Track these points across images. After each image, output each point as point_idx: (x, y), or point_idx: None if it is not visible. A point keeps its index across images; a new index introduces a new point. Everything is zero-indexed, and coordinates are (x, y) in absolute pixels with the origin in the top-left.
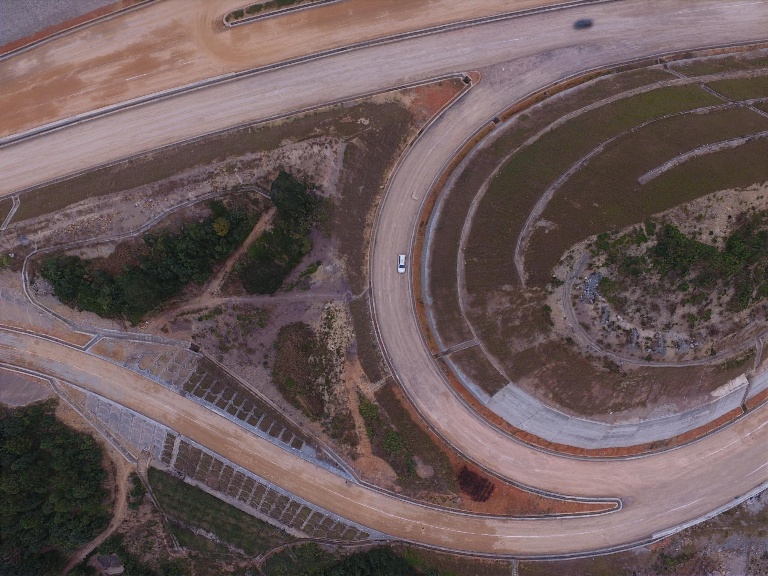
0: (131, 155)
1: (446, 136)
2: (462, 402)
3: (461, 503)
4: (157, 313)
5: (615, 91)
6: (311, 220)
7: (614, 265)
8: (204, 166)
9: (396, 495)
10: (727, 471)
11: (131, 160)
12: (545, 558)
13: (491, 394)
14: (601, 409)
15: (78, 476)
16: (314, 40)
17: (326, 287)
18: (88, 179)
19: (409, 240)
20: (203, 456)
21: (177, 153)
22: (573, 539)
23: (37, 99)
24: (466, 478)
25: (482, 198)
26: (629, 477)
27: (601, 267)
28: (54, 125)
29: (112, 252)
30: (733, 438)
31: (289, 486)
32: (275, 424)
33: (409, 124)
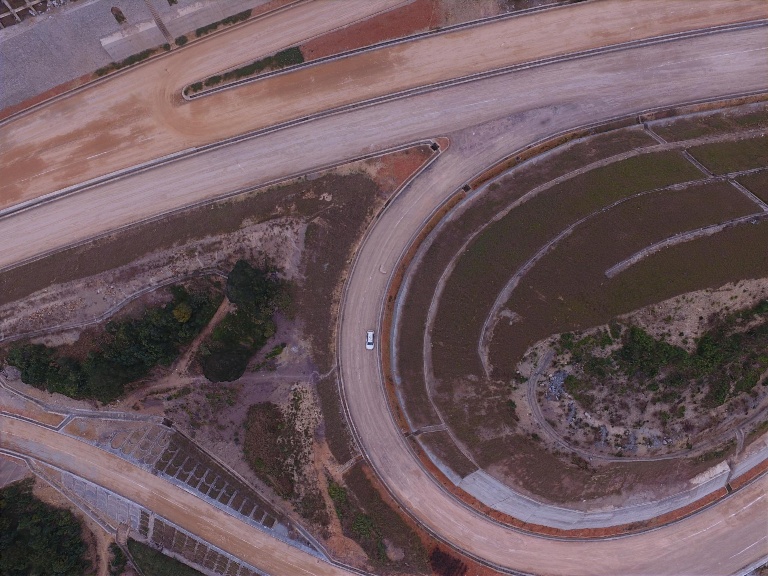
0: (95, 235)
1: (414, 206)
2: (434, 481)
3: None
4: (127, 391)
5: (589, 160)
6: (273, 305)
7: (579, 364)
8: (164, 251)
9: (368, 574)
10: (710, 553)
11: (95, 240)
12: None
13: (462, 476)
14: (573, 498)
15: (57, 552)
16: (276, 110)
17: (292, 368)
18: (53, 261)
19: (377, 315)
20: (177, 533)
21: (140, 232)
22: None
23: (0, 181)
24: (438, 559)
25: (449, 277)
26: (607, 558)
27: (566, 365)
28: (18, 207)
29: (76, 339)
30: (717, 519)
31: (261, 564)
32: (247, 502)
33: (375, 195)
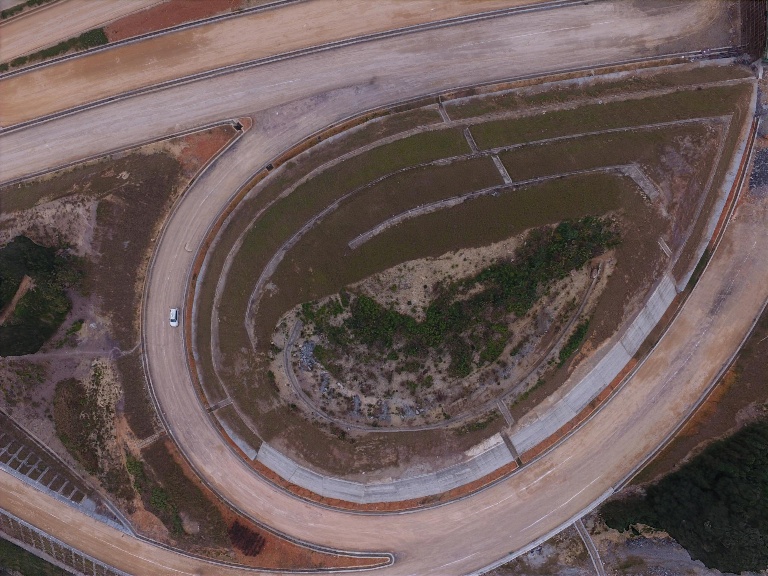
0: None
1: (219, 185)
2: (235, 456)
3: (234, 557)
4: None
5: (375, 137)
6: (62, 281)
7: (323, 334)
8: None
9: (172, 548)
10: (501, 526)
11: None
12: None
13: (256, 450)
14: (350, 470)
15: None
16: (82, 91)
17: (92, 344)
18: None
19: (183, 293)
20: None
21: None
22: None
23: None
24: (236, 533)
25: (236, 254)
26: (402, 531)
27: (312, 335)
28: None
29: None
30: (508, 492)
31: (69, 539)
32: (58, 477)
33: (179, 174)
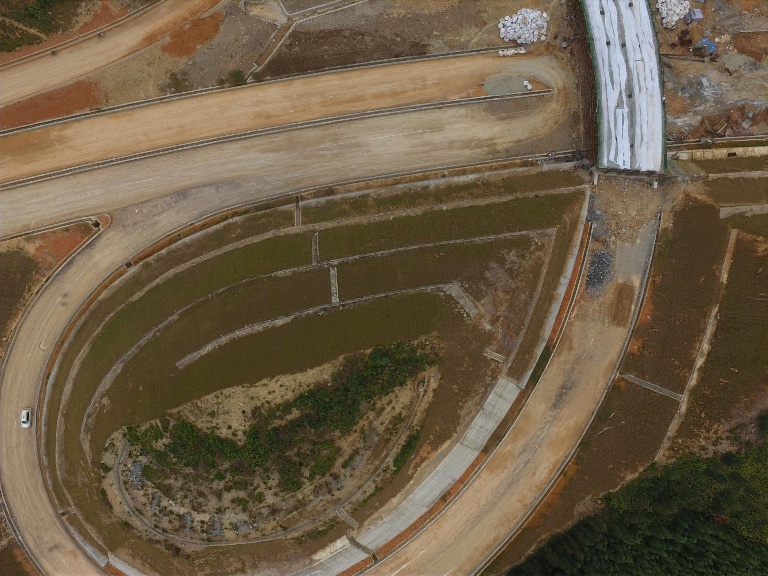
0: None
1: (76, 282)
2: (89, 561)
3: None
4: None
5: (227, 241)
6: None
7: (150, 455)
8: None
9: None
10: None
11: None
12: None
13: (107, 556)
14: None
15: None
16: None
17: None
18: None
19: (37, 392)
20: None
21: None
22: None
23: None
24: None
25: (84, 358)
26: None
27: (140, 456)
28: None
29: None
30: None
31: None
32: None
33: (34, 272)
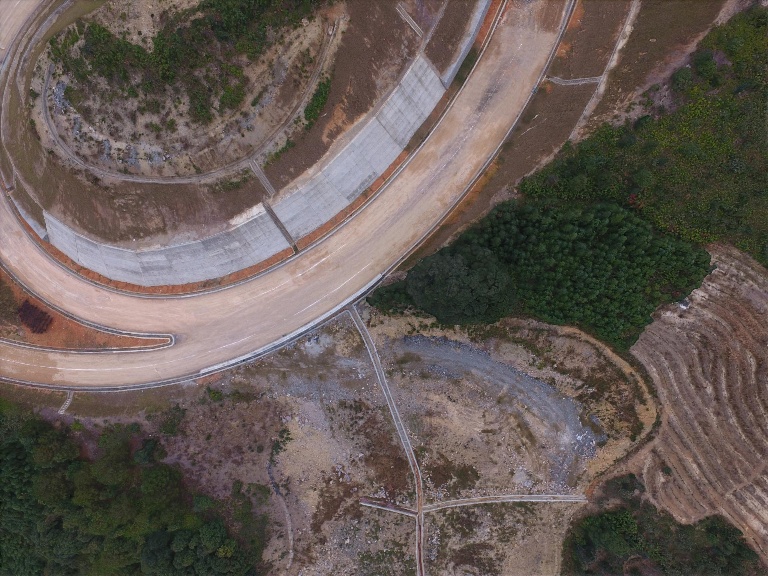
0: None
1: None
2: (32, 241)
3: (23, 336)
4: None
5: None
6: None
7: (71, 72)
8: None
9: None
10: (277, 310)
11: None
12: (99, 390)
13: (46, 229)
14: (119, 234)
15: None
16: None
17: None
18: None
19: None
20: None
21: None
22: (128, 373)
23: None
24: (25, 310)
25: None
26: (184, 315)
27: (62, 75)
28: None
29: None
30: (285, 278)
31: None
32: None
33: None
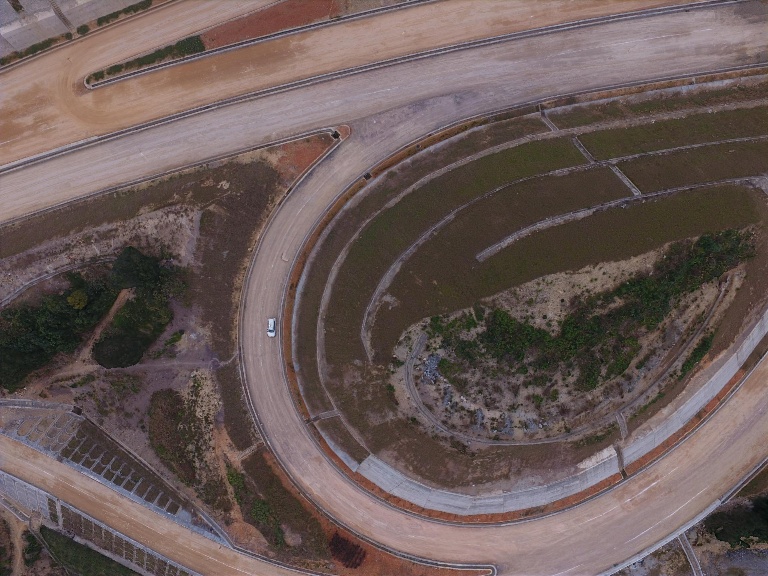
0: None
1: (316, 194)
2: (334, 467)
3: (333, 569)
4: (34, 379)
5: (482, 147)
6: (167, 292)
7: (451, 347)
8: (61, 238)
9: (270, 560)
10: (606, 538)
11: None
12: None
13: (359, 462)
14: (461, 482)
15: None
16: (178, 99)
17: (191, 355)
18: None
19: (280, 303)
20: (84, 519)
21: (43, 221)
22: None
23: None
24: (337, 545)
25: (342, 264)
26: (504, 543)
27: (438, 349)
28: None
29: None
30: (612, 504)
31: (165, 550)
32: (152, 488)
33: (276, 183)
